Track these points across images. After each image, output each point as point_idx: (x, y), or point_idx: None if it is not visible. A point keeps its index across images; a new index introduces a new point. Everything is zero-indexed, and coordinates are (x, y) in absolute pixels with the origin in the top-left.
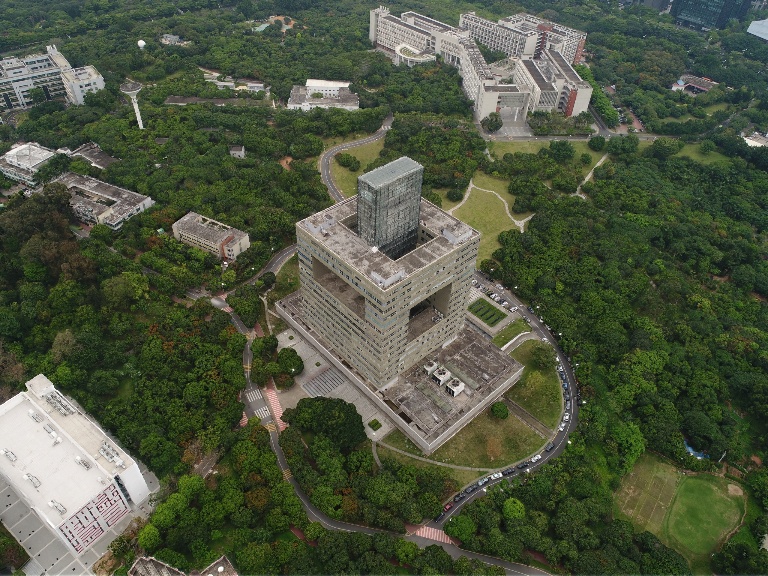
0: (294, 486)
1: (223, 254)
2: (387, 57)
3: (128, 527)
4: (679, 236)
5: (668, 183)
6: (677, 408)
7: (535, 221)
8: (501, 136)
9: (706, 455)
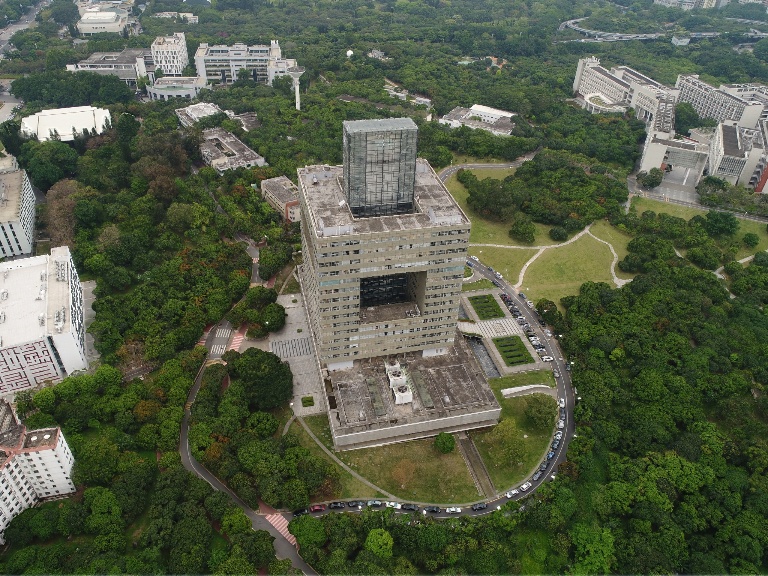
0: None
1: (288, 216)
2: None
3: None
4: None
5: None
6: (687, 542)
7: (635, 281)
8: (656, 195)
9: None
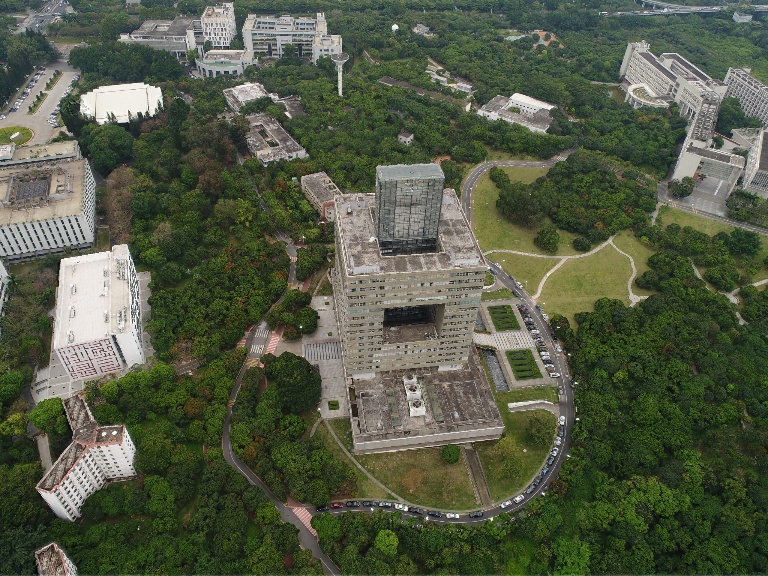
0: None
1: (325, 215)
2: None
3: None
4: None
5: None
6: (655, 562)
7: (648, 301)
8: (685, 205)
9: None
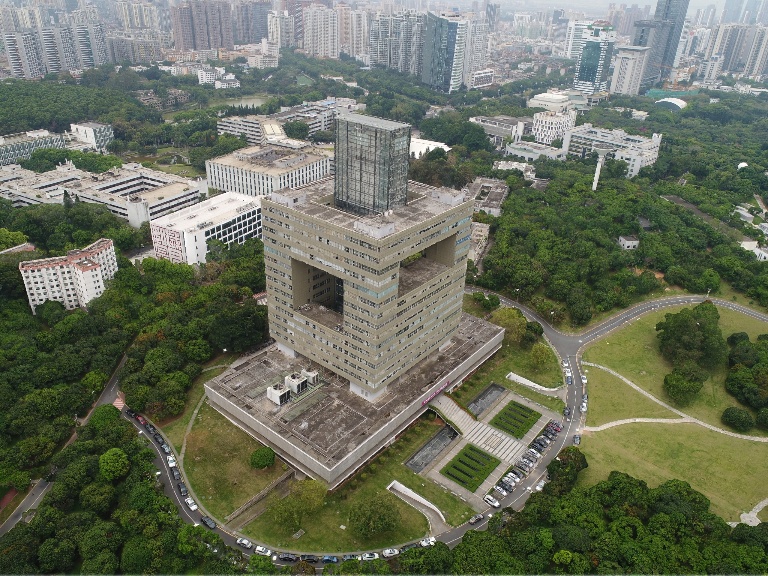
0: None
1: None
2: None
3: None
4: None
5: None
6: None
7: None
8: None
9: None
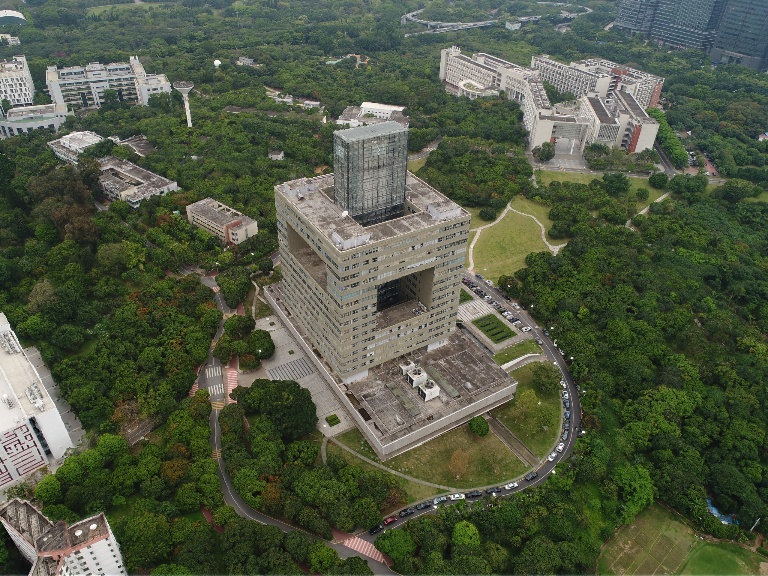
0: (222, 467)
1: (228, 239)
2: (454, 94)
3: (31, 475)
4: (740, 278)
5: (736, 226)
6: (703, 458)
7: (570, 245)
8: (552, 166)
9: (735, 520)
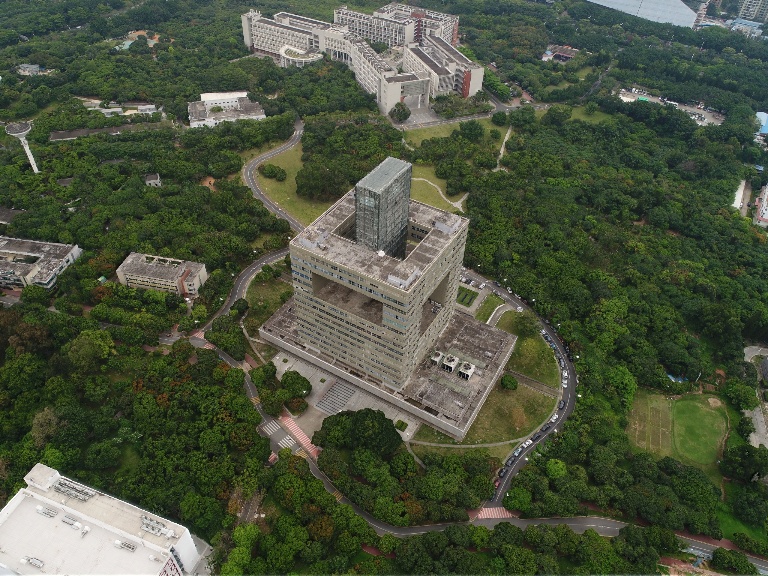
0: None
1: (182, 290)
2: None
3: None
4: (597, 191)
5: (571, 145)
6: (650, 343)
7: (473, 200)
8: (411, 124)
9: (684, 378)
